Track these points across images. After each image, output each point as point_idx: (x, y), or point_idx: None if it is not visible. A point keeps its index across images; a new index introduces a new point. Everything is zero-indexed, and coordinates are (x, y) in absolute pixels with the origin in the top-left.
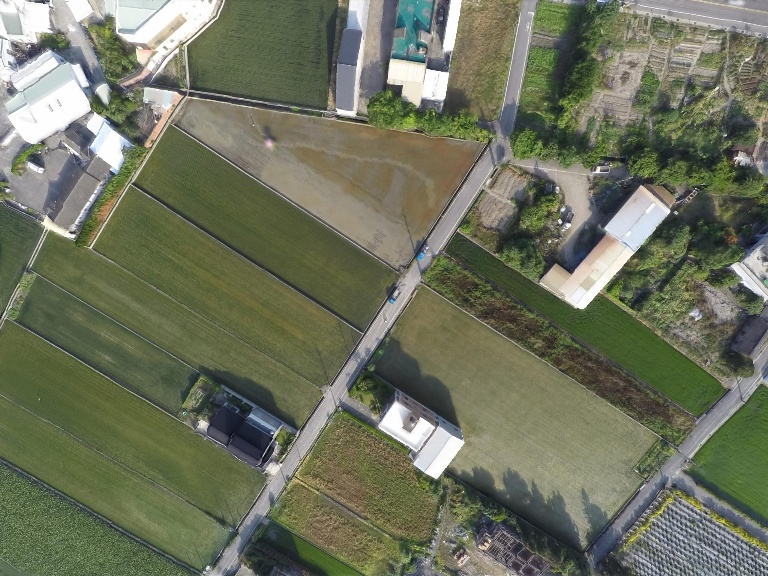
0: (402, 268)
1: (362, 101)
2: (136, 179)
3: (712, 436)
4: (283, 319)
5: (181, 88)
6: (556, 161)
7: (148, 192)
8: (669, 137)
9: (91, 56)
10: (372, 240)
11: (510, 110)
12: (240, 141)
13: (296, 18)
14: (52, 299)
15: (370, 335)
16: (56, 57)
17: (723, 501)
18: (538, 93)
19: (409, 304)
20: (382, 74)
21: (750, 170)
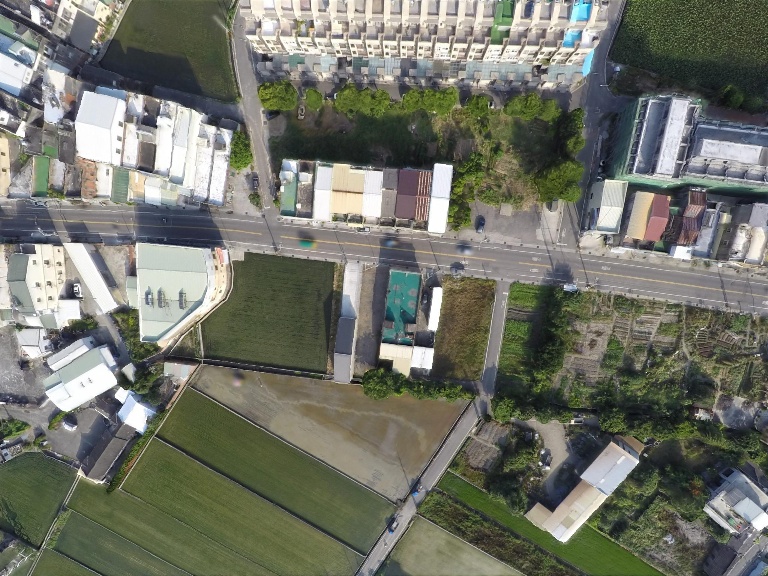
0: (399, 501)
1: (358, 365)
2: (158, 431)
3: None
4: (293, 545)
5: (196, 357)
6: (534, 417)
7: (169, 442)
8: (635, 394)
9: (116, 333)
10: (371, 478)
11: (491, 372)
12: (250, 398)
13: (296, 299)
14: (86, 530)
15: (372, 557)
16: (86, 342)
17: None
18: (515, 358)
19: (407, 532)
20: (375, 343)
21: (710, 427)
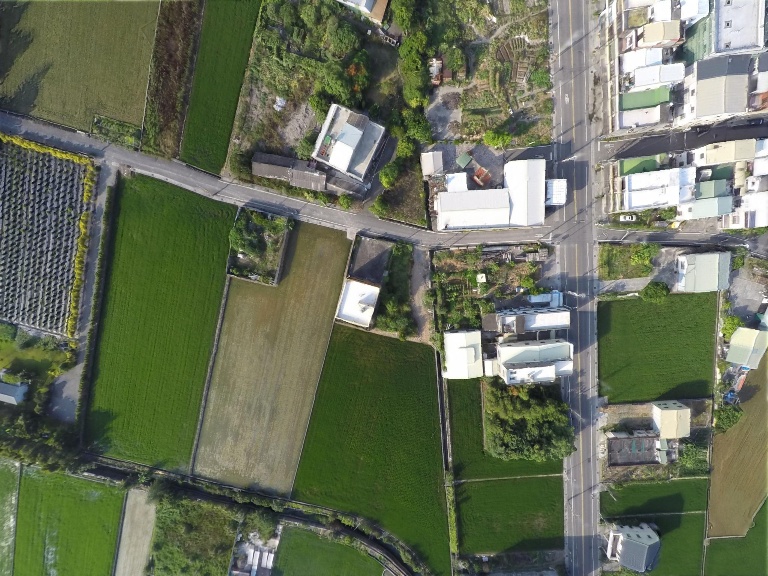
0: None
1: None
2: None
3: (167, 182)
4: None
5: None
6: None
7: None
8: None
9: None
10: None
11: None
12: None
13: None
14: None
15: None
16: None
17: (104, 221)
18: None
19: None
20: None
21: (426, 74)
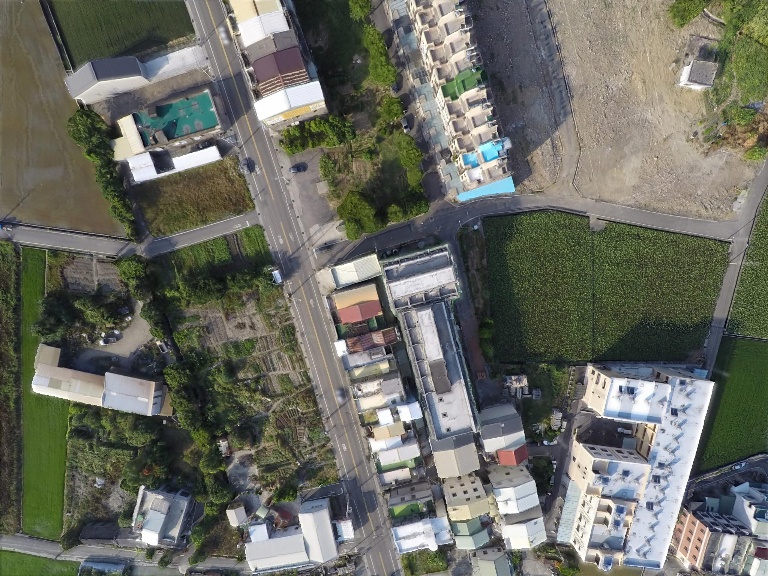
0: None
1: (103, 105)
2: None
3: (15, 552)
4: None
5: None
6: None
7: None
8: (214, 384)
9: None
10: None
11: (167, 245)
12: None
13: (137, 6)
14: None
15: None
16: None
17: None
18: (192, 262)
19: None
20: None
21: (215, 456)
